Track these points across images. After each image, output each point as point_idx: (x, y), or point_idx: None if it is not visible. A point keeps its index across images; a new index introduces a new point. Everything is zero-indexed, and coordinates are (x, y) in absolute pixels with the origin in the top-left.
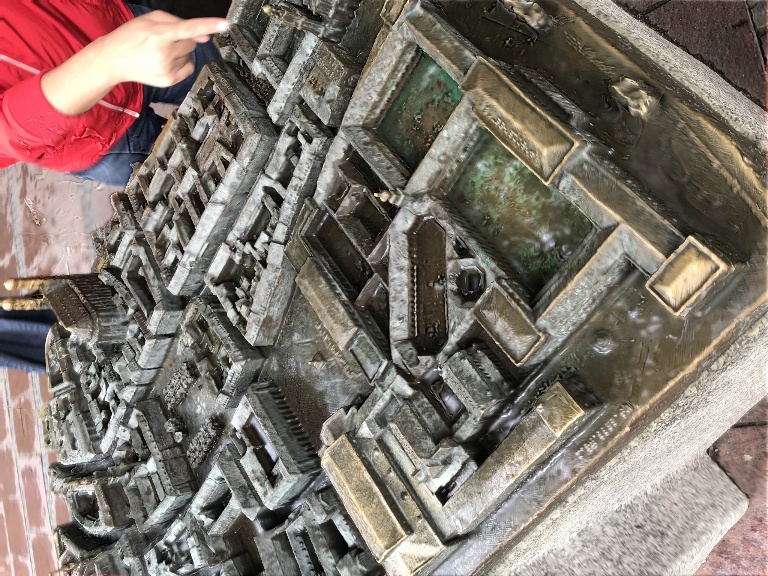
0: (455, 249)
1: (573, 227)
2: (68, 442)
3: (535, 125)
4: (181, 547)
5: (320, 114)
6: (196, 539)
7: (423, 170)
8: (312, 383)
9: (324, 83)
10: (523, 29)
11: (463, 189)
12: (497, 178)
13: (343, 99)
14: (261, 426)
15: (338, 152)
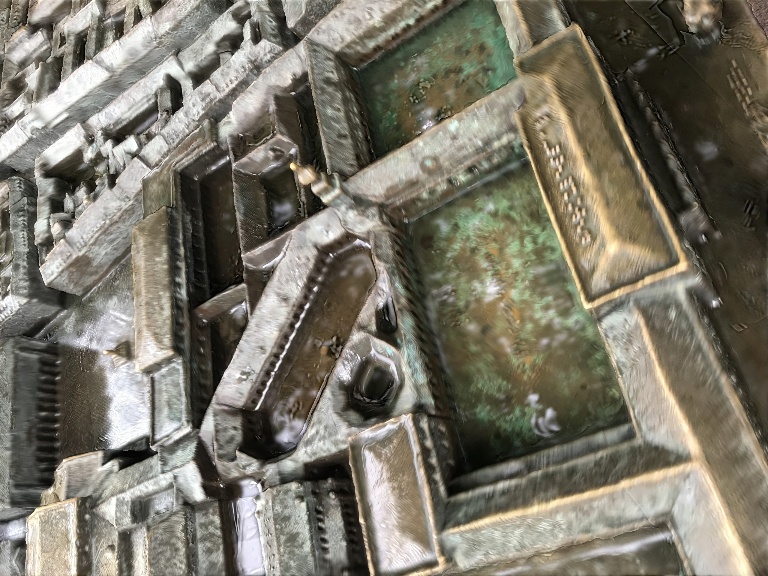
0: (377, 316)
1: (582, 389)
2: None
3: (620, 190)
4: None
5: (288, 7)
6: None
7: (390, 166)
8: (100, 378)
9: None
10: (660, 25)
11: (437, 228)
12: (497, 240)
13: (332, 3)
14: None
15: (283, 75)
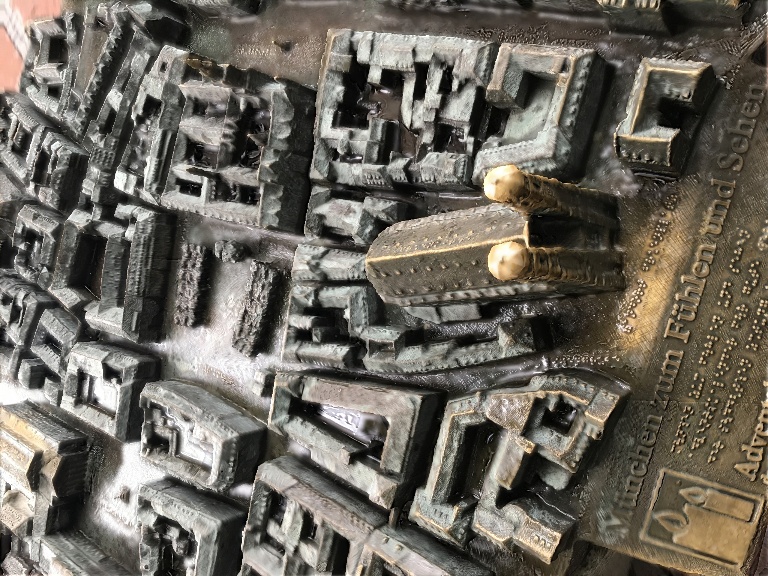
0: None
1: None
2: None
3: None
4: (150, 146)
5: None
6: None
7: None
8: (125, 468)
9: None
10: None
11: None
12: None
13: None
14: (97, 418)
15: None
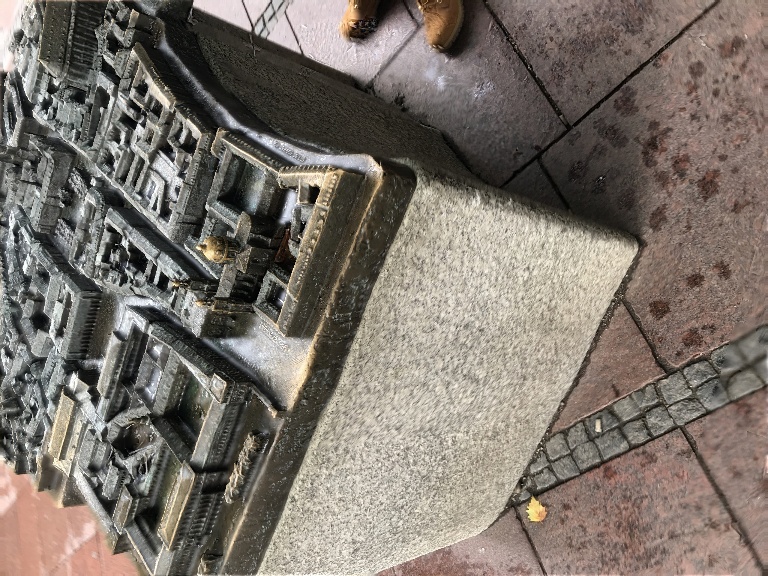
0: None
1: None
2: (22, 65)
3: (172, 523)
4: None
5: None
6: (31, 262)
7: None
8: (109, 331)
9: (192, 317)
10: None
11: None
12: None
13: None
14: None
15: None
